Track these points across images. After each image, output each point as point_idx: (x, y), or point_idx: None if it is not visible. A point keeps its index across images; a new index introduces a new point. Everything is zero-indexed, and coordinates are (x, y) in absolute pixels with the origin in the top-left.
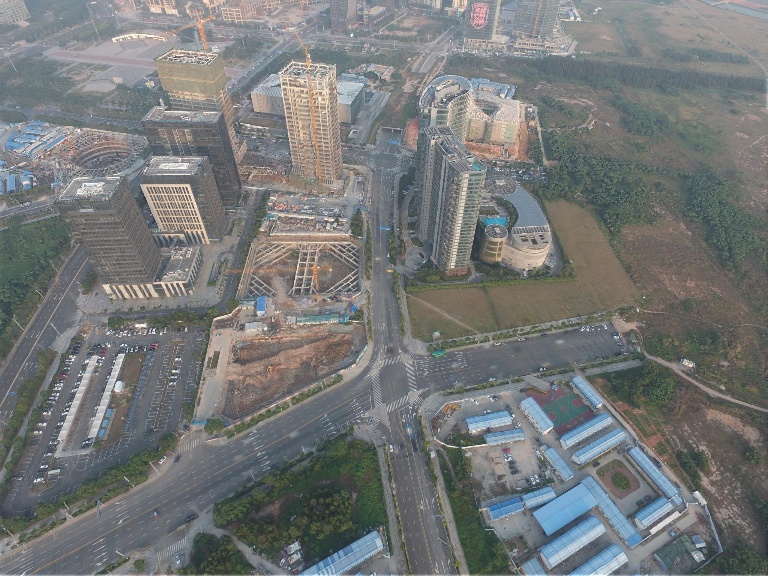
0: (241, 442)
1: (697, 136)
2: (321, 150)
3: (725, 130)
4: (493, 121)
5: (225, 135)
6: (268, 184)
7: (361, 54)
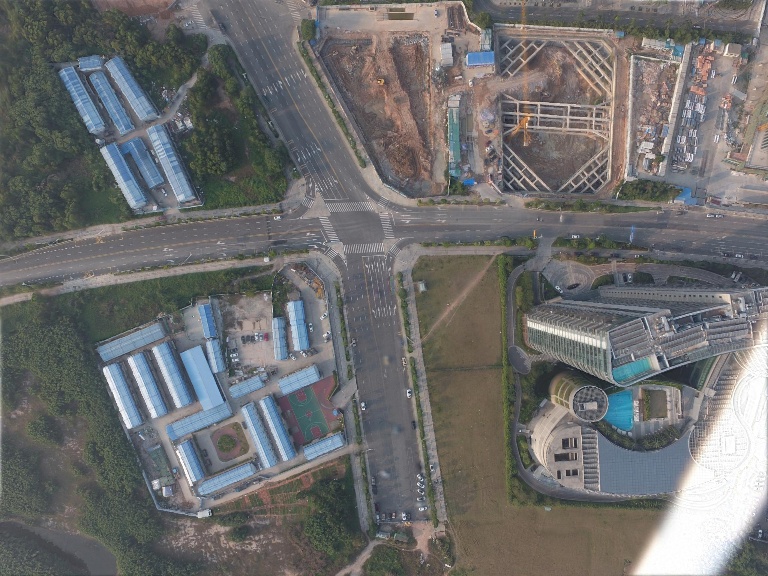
0: (294, 62)
1: None
2: None
3: None
4: None
5: None
6: None
7: None
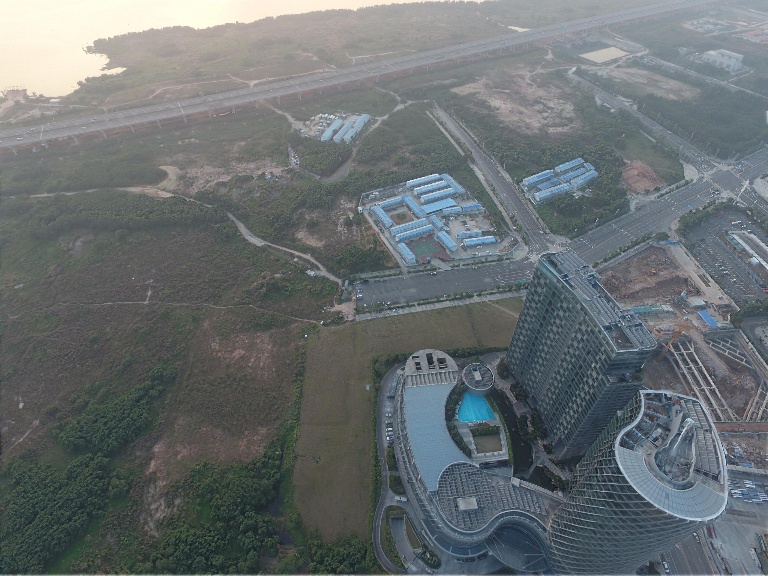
0: (638, 235)
1: None
2: None
3: None
4: None
5: None
6: None
7: None
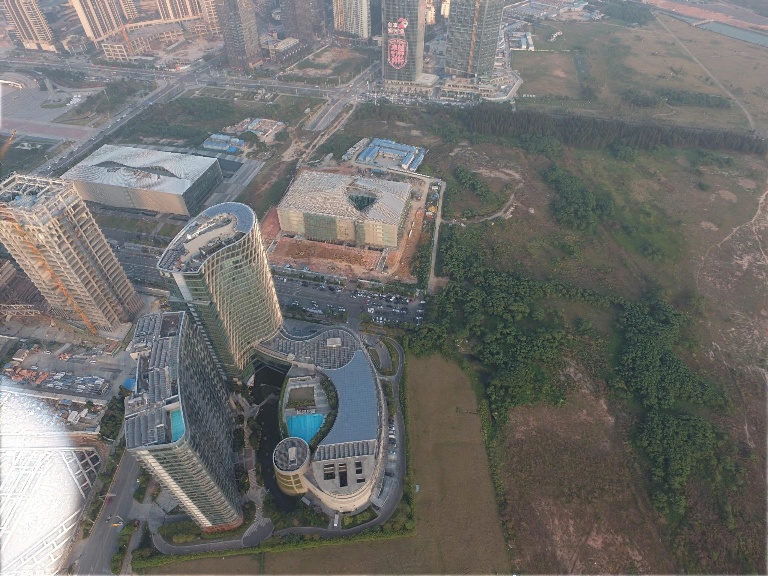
0: None
1: (648, 230)
2: (78, 294)
3: (687, 218)
4: (363, 221)
5: None
6: (31, 327)
7: (252, 103)
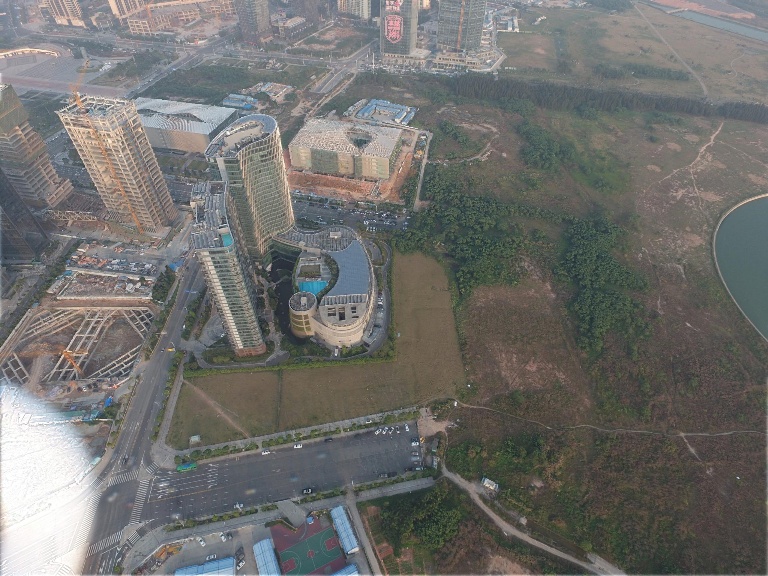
0: None
1: (601, 170)
2: (131, 196)
3: (636, 162)
4: (361, 155)
5: (5, 182)
6: (88, 231)
7: (264, 71)
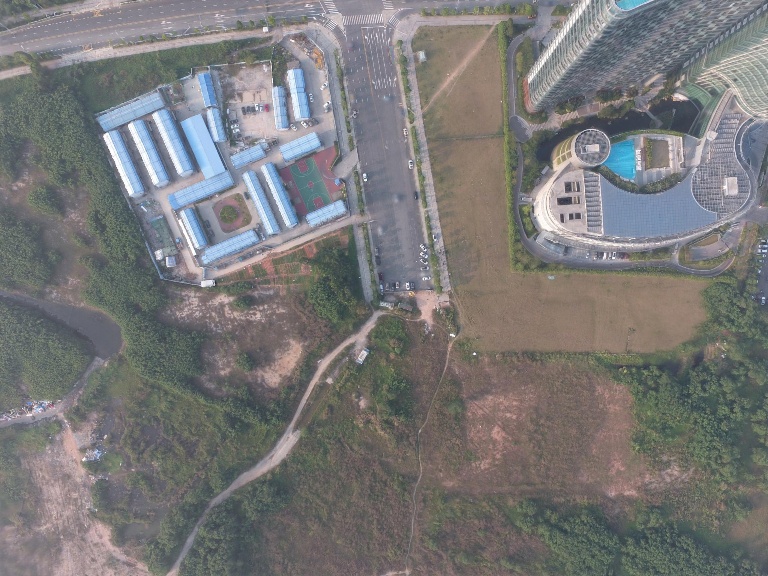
0: None
1: None
2: None
3: None
4: None
5: None
6: None
7: None
